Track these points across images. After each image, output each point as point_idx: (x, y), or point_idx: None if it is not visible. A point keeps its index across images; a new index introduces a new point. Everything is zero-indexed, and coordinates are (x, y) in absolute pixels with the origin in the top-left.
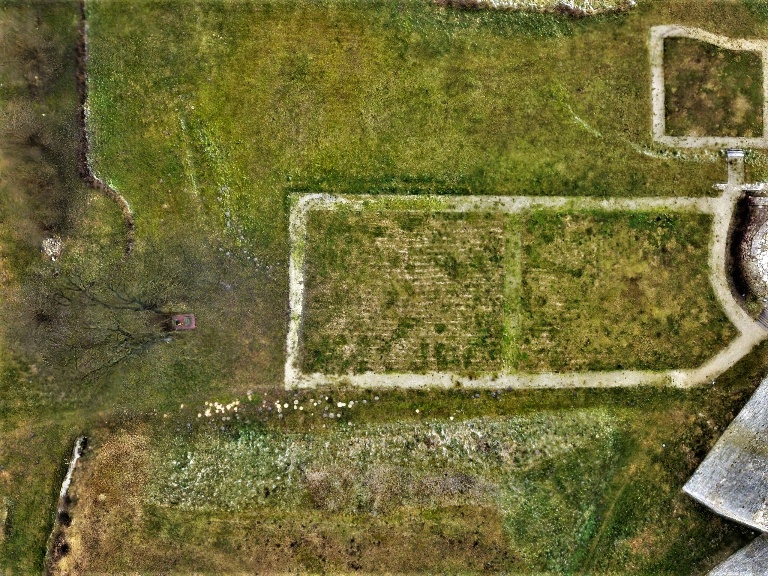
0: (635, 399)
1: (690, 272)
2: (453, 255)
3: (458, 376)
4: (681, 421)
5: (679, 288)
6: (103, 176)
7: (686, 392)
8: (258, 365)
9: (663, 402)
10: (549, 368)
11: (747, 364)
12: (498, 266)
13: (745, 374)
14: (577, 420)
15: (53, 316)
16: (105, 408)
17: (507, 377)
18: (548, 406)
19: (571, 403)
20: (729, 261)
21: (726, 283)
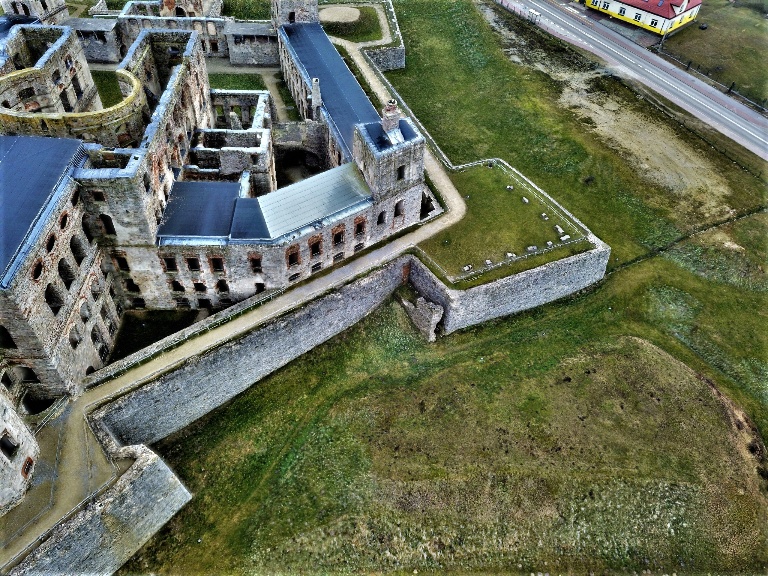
0: None
1: None
2: None
3: None
4: (175, 567)
5: None
6: None
7: None
8: None
9: None
10: None
11: None
12: None
13: None
14: (285, 569)
15: None
16: None
17: None
18: None
19: None
20: None
21: None
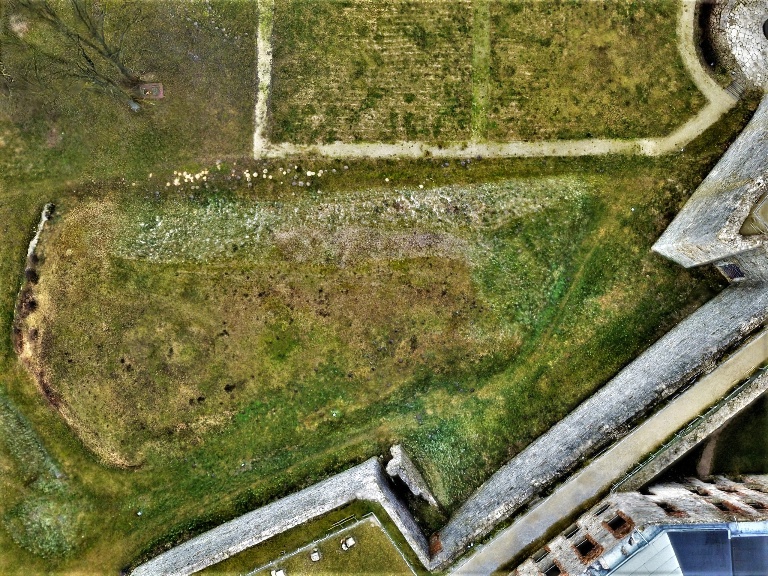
0: (604, 166)
1: (659, 41)
2: (422, 25)
3: (428, 146)
4: (650, 187)
5: (648, 57)
6: None
7: (655, 160)
8: (227, 135)
9: (632, 169)
10: (518, 137)
11: (716, 132)
12: (467, 36)
13: (714, 141)
14: (546, 186)
15: (11, 16)
16: (73, 177)
17: (476, 146)
18: (517, 174)
19: (540, 171)
20: (698, 32)
21: (695, 52)
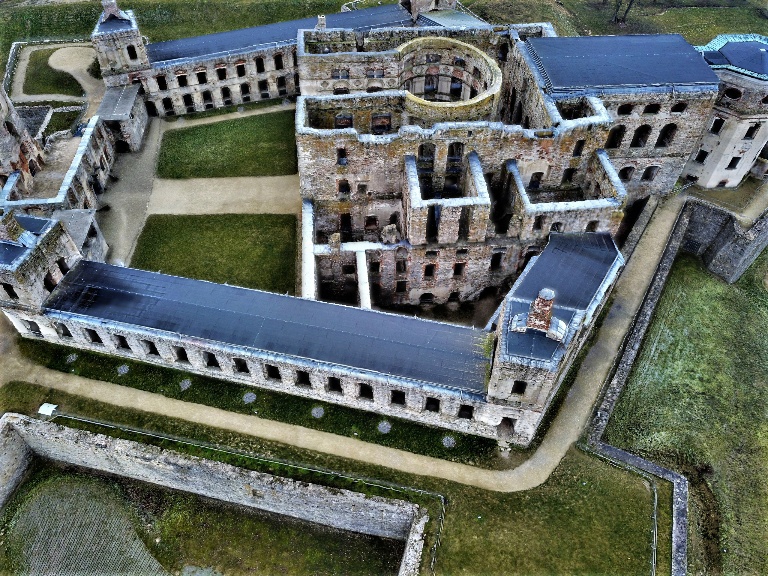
0: None
1: None
2: None
3: None
4: None
5: None
6: (669, 10)
7: None
8: None
9: None
10: None
11: None
12: None
13: None
14: None
15: None
16: None
17: None
18: None
19: None
20: None
21: None
